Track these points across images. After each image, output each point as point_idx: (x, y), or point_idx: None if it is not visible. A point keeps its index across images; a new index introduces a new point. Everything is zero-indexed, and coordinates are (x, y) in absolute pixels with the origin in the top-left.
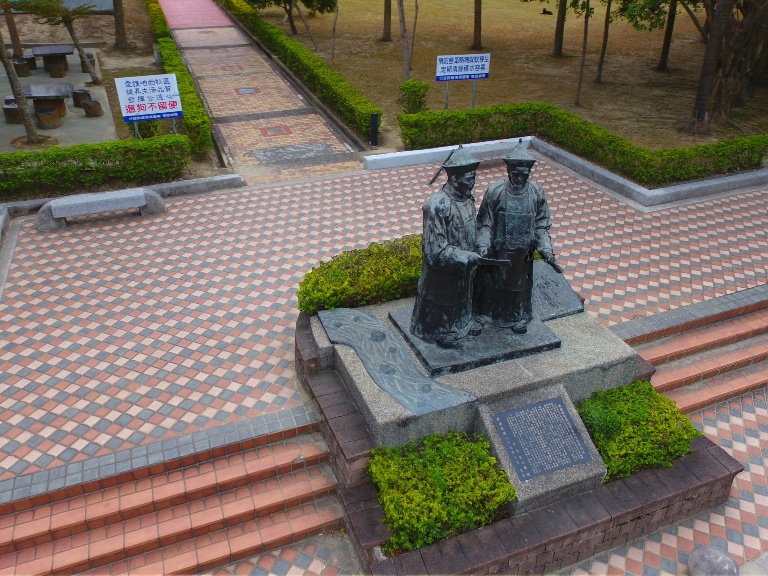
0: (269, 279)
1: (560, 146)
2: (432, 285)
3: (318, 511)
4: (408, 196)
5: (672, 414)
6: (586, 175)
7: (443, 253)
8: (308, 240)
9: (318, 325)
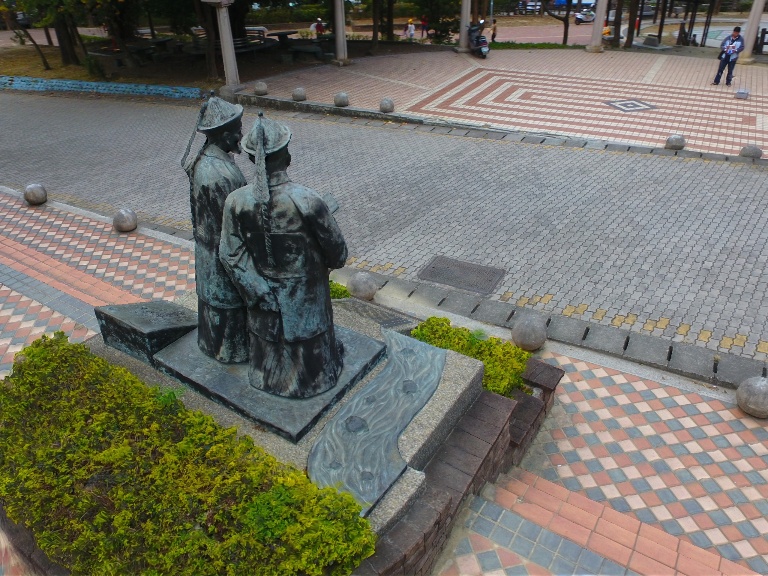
0: None
1: None
2: None
3: None
4: None
5: None
6: None
7: None
8: None
9: (380, 513)
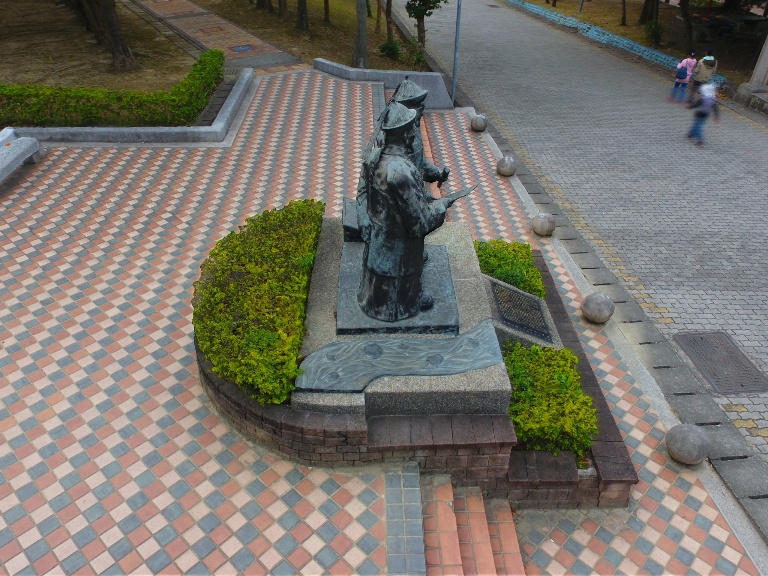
0: (69, 453)
1: (45, 127)
2: (412, 256)
3: (497, 522)
4: (2, 257)
5: (509, 246)
6: (129, 140)
7: (431, 214)
8: (2, 382)
9: (315, 396)
